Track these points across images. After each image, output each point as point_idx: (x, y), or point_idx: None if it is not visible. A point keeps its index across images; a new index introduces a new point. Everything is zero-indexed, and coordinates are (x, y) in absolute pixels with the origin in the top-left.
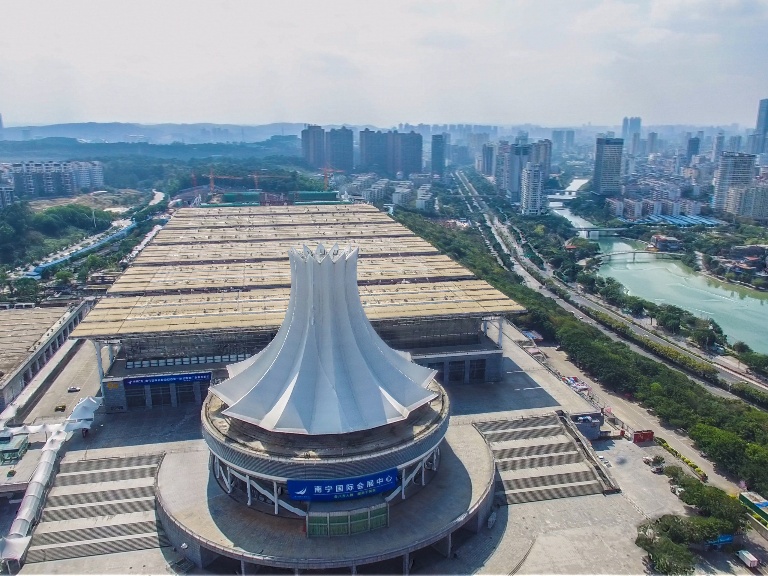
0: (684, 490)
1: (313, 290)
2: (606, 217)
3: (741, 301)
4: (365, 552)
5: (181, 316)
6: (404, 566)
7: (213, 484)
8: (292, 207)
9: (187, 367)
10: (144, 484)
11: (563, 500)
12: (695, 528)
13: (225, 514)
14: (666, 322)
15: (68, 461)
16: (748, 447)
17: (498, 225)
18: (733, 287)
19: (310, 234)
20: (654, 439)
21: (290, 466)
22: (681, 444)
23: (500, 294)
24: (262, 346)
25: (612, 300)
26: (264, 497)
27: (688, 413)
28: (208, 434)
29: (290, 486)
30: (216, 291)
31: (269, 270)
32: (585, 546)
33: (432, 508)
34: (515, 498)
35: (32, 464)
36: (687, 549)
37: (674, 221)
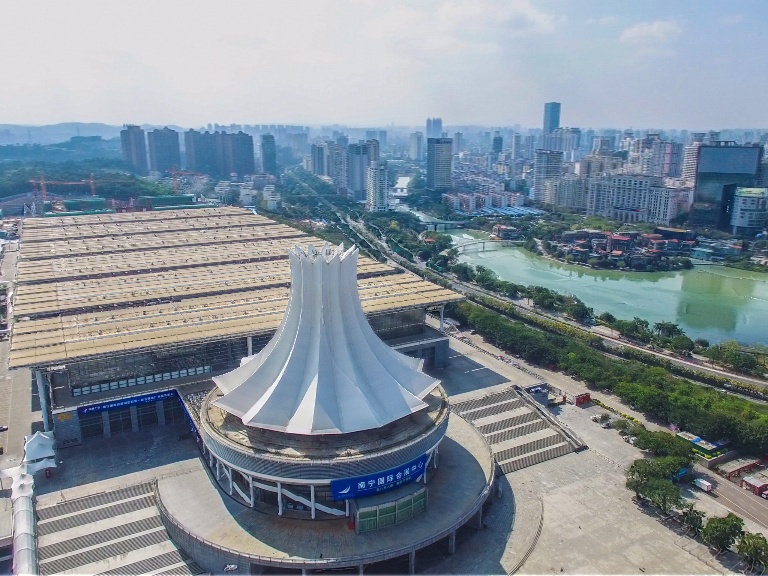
0: (637, 438)
1: (322, 290)
2: (446, 211)
3: (580, 279)
4: (419, 537)
5: (128, 333)
6: (451, 543)
7: (229, 501)
8: (156, 212)
9: (144, 387)
10: (147, 515)
11: (547, 463)
12: (664, 467)
13: (261, 528)
14: (544, 301)
15: (45, 506)
16: (670, 396)
17: (352, 223)
18: (573, 267)
19: (200, 239)
20: (591, 400)
21: (334, 467)
22: (611, 402)
23: (433, 285)
24: (222, 356)
25: (488, 286)
26: (294, 504)
27: (609, 375)
28: (228, 449)
29: (334, 487)
30: (142, 304)
31: (186, 278)
32: (584, 498)
33: (455, 487)
34: (508, 468)
35: (2, 516)
36: (672, 483)
37: (505, 212)
